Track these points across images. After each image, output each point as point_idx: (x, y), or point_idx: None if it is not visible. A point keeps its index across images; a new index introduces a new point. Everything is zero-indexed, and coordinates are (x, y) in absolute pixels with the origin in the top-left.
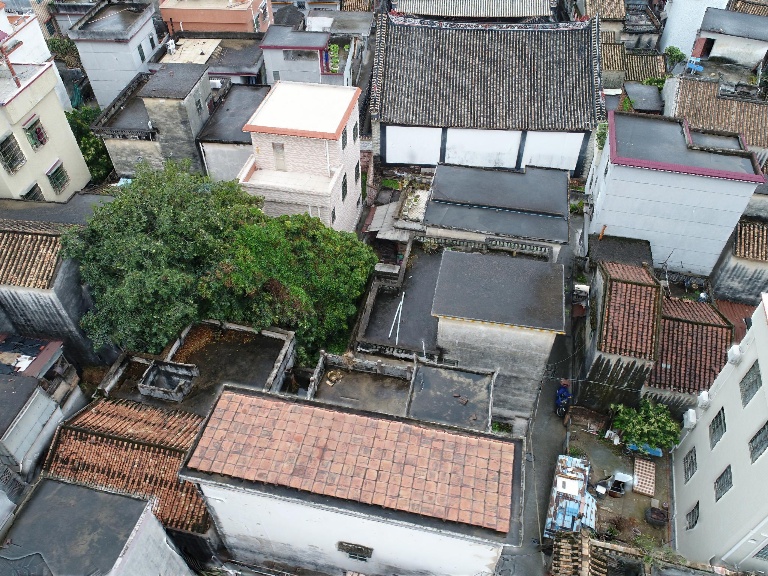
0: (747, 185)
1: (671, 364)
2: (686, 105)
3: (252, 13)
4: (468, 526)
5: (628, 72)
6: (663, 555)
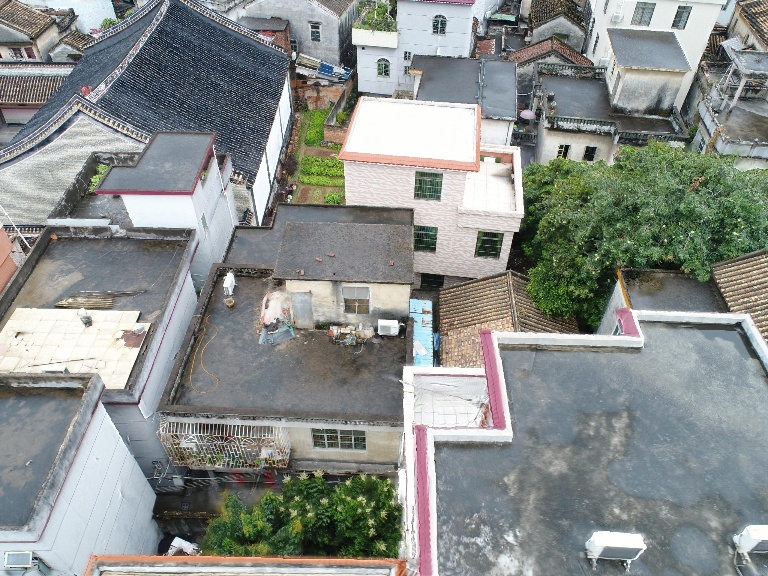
0: None
1: None
2: None
3: None
4: None
5: None
6: None
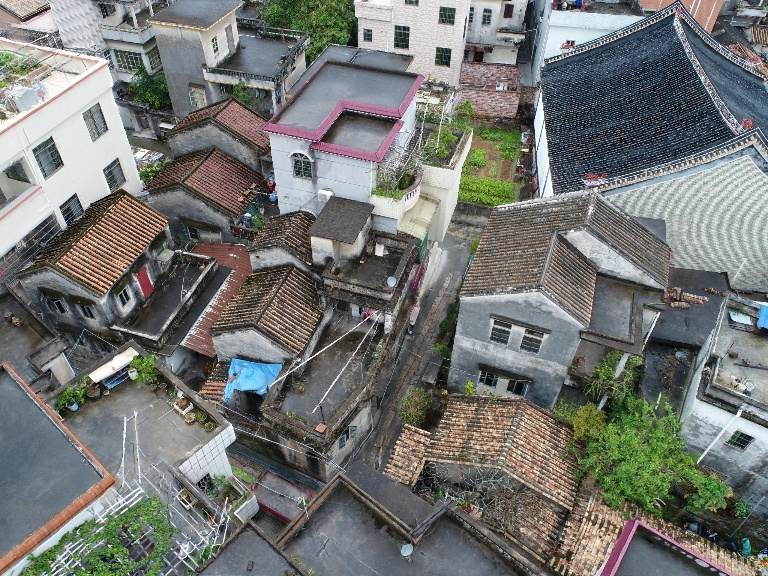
0: None
1: None
2: None
3: None
4: None
5: None
6: None
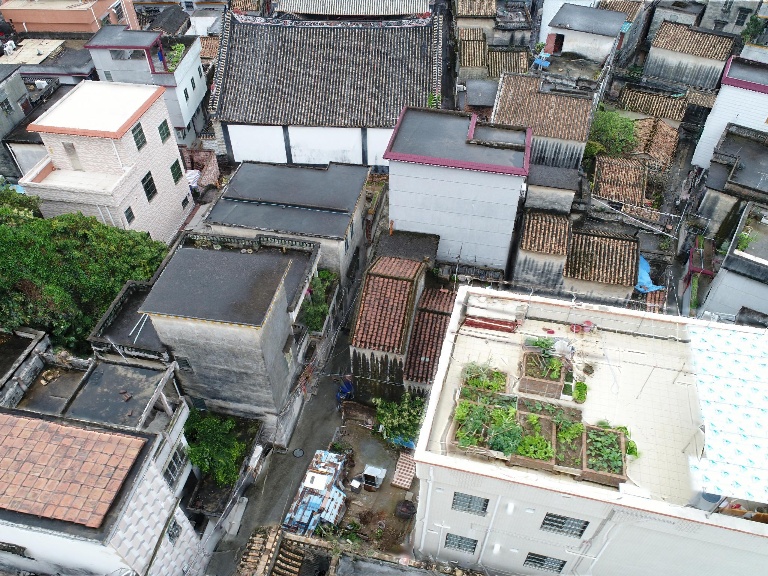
0: (513, 178)
1: (430, 357)
2: (508, 100)
3: (93, 13)
4: (60, 522)
5: (491, 68)
6: (351, 547)
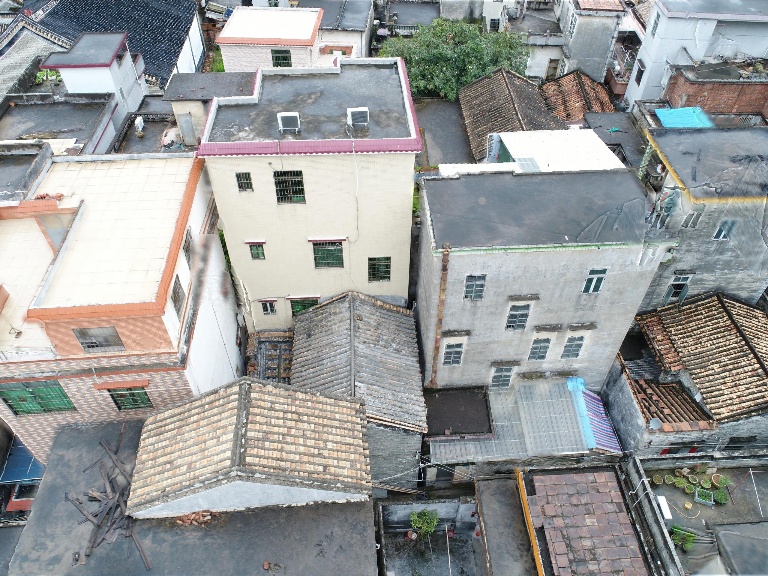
0: None
1: None
2: None
3: None
4: None
5: None
6: None
